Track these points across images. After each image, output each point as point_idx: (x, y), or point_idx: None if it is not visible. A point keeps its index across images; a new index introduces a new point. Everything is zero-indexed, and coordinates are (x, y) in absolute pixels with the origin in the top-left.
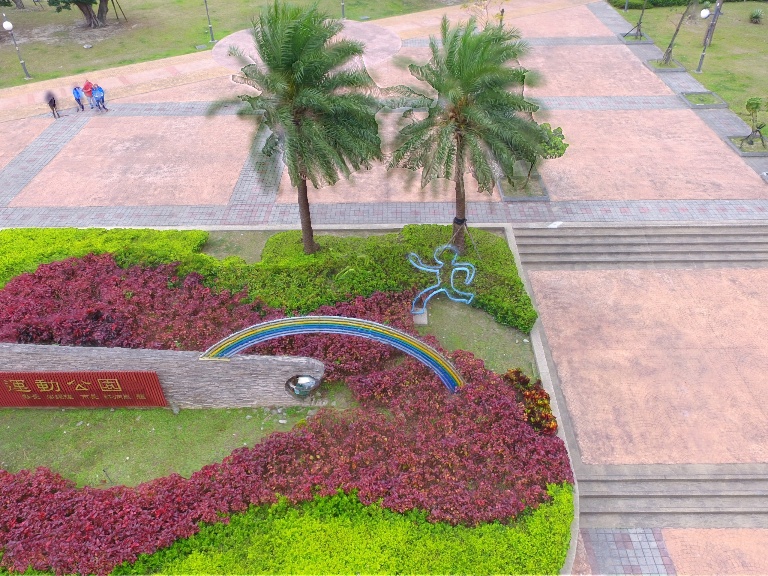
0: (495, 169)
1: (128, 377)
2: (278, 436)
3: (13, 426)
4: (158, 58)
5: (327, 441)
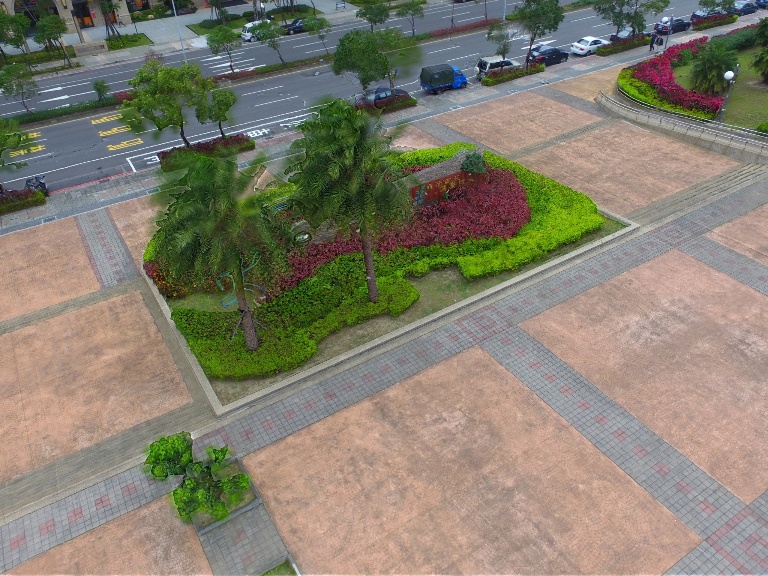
0: None
1: None
2: None
3: None
4: None
5: None
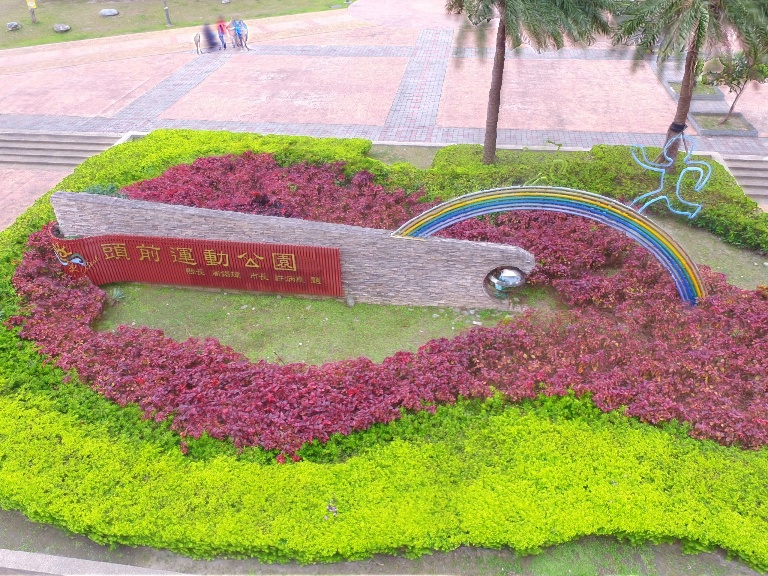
0: (760, 38)
1: (307, 253)
2: (482, 330)
3: (172, 304)
4: (294, 13)
5: (542, 340)
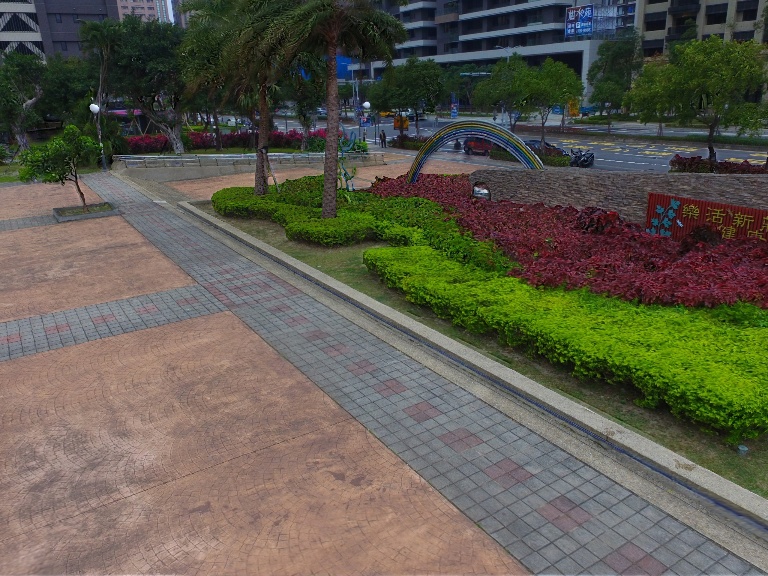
0: None
1: None
2: None
3: None
4: None
5: None
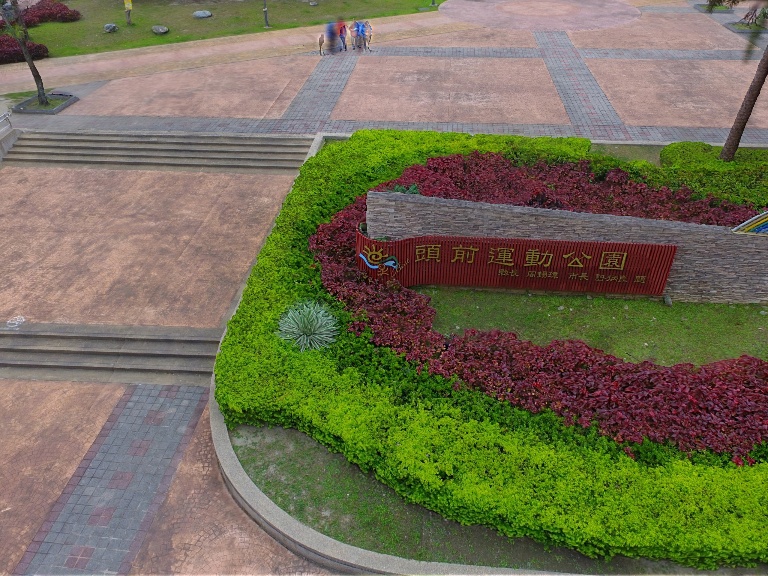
0: None
1: (641, 251)
2: None
3: (482, 306)
4: (388, 15)
5: None
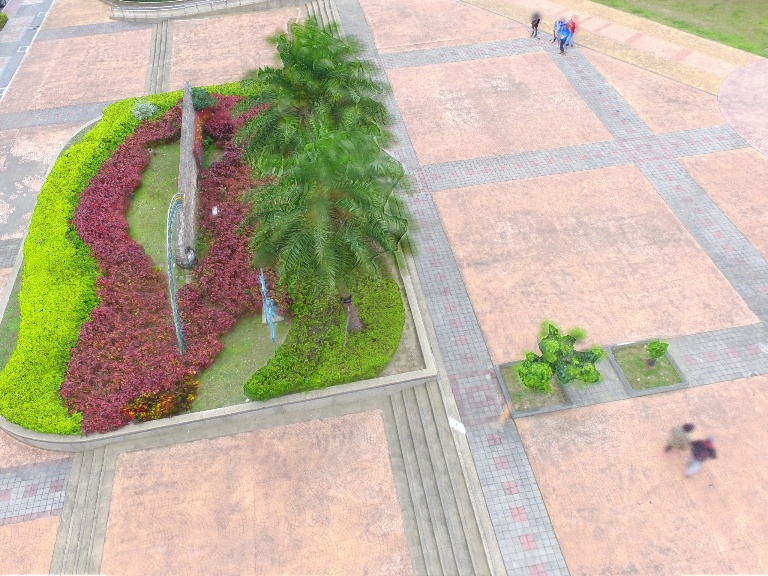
0: None
1: None
2: (146, 260)
3: None
4: (707, 36)
5: None
